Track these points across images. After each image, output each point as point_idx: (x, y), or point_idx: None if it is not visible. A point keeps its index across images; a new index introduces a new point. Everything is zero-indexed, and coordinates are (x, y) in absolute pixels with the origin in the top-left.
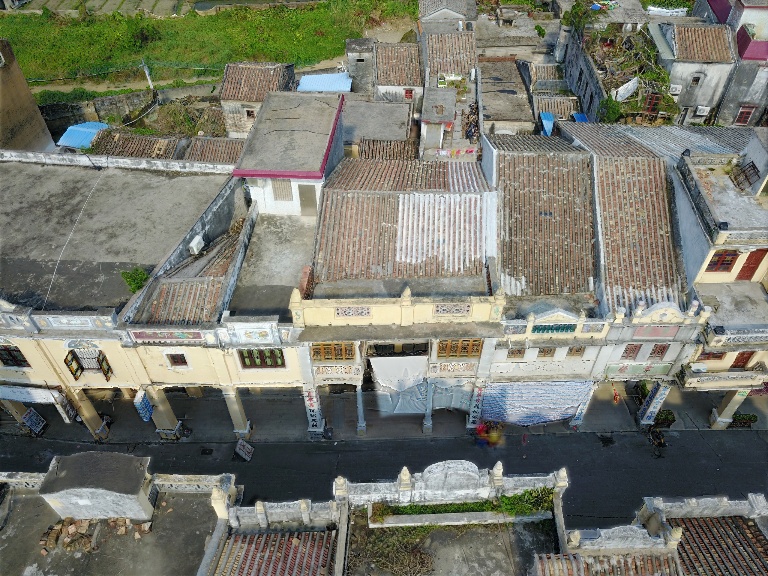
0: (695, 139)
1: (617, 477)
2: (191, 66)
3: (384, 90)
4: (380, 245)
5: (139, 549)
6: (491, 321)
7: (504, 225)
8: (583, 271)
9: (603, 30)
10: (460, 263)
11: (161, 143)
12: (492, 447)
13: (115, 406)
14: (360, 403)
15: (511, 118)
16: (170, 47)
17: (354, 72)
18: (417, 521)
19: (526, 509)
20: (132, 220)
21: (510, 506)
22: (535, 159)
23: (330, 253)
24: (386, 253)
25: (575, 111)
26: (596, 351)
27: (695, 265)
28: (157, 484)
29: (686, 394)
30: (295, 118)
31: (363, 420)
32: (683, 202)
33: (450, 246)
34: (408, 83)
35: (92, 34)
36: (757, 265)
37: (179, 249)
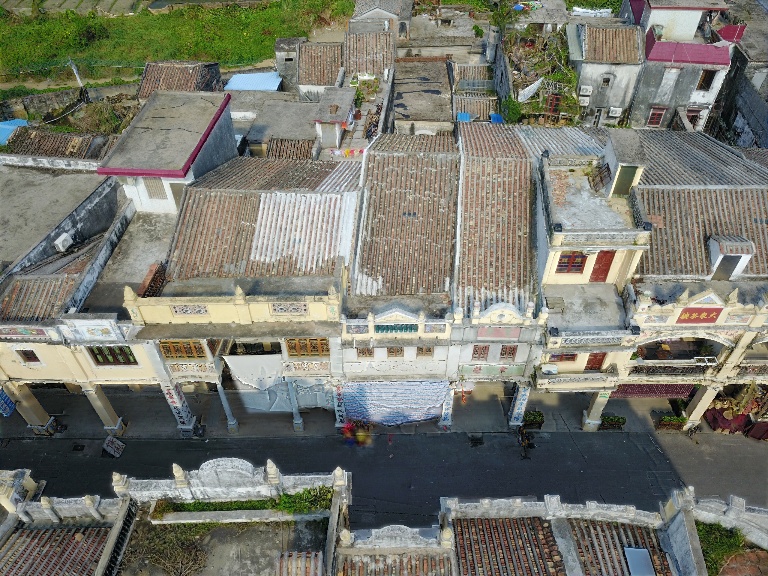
0: (582, 140)
1: (480, 478)
2: (133, 64)
3: (306, 89)
4: (236, 244)
5: None
6: (329, 320)
7: (367, 225)
8: (441, 271)
9: (524, 30)
10: (313, 262)
11: (76, 141)
12: (361, 446)
13: None
14: (224, 401)
15: (430, 118)
16: (116, 45)
17: (284, 71)
18: (196, 518)
19: (304, 507)
20: (6, 217)
21: (289, 504)
22: (405, 159)
23: (185, 251)
24: (241, 252)
25: (493, 111)
26: (445, 351)
27: (542, 266)
28: None
29: (564, 395)
30: (176, 117)
31: (232, 418)
32: (540, 203)
33: (305, 245)
34: (328, 82)
35: (41, 32)
36: (608, 267)
37: (42, 246)
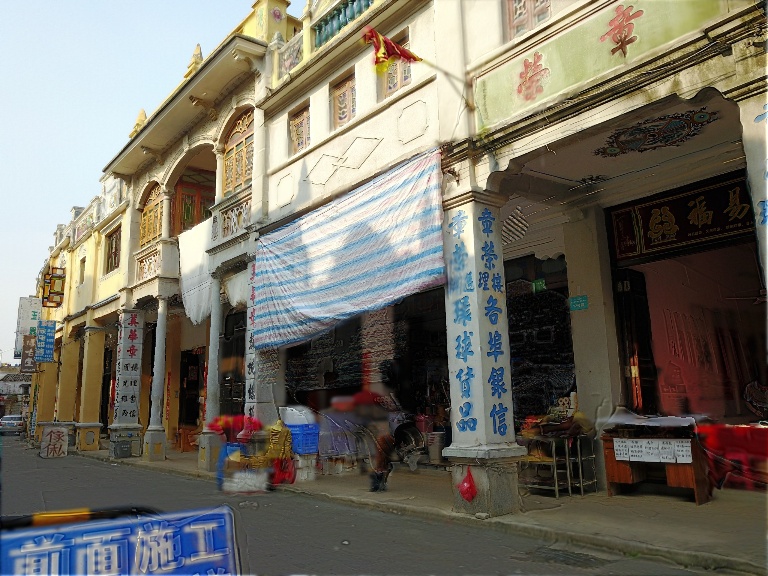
0: None
1: None
2: None
3: None
4: None
5: None
6: None
7: None
8: None
9: None
10: None
11: None
12: (236, 493)
13: None
14: (157, 355)
15: None
16: None
17: None
18: None
19: None
20: None
21: None
22: None
23: None
24: None
25: None
26: None
27: None
28: None
29: None
30: None
31: (156, 414)
32: None
33: None
34: None
35: None
36: None
37: None
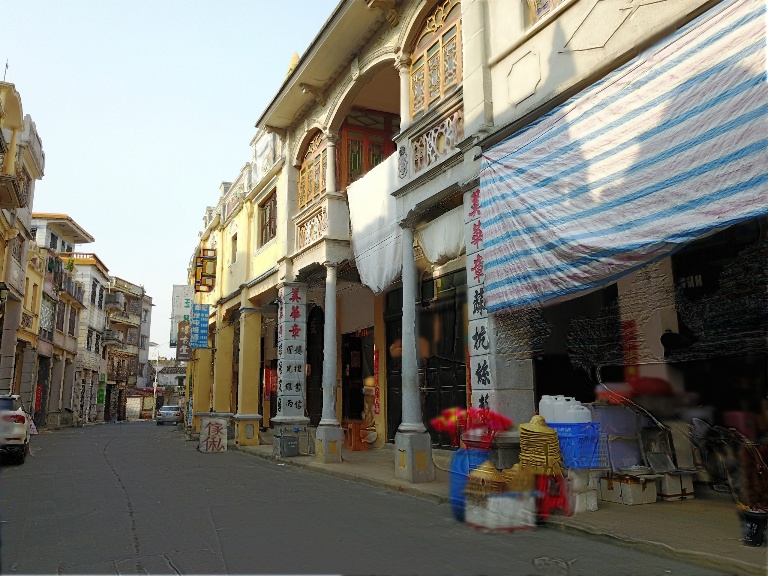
0: None
1: None
2: None
3: None
4: None
5: None
6: None
7: None
8: None
9: None
10: None
11: None
12: (487, 528)
13: None
14: (327, 334)
15: None
16: None
17: None
18: None
19: None
20: None
21: None
22: None
23: None
24: None
25: None
26: None
27: None
28: None
29: None
30: None
31: (328, 406)
32: None
33: None
34: None
35: None
36: None
37: None
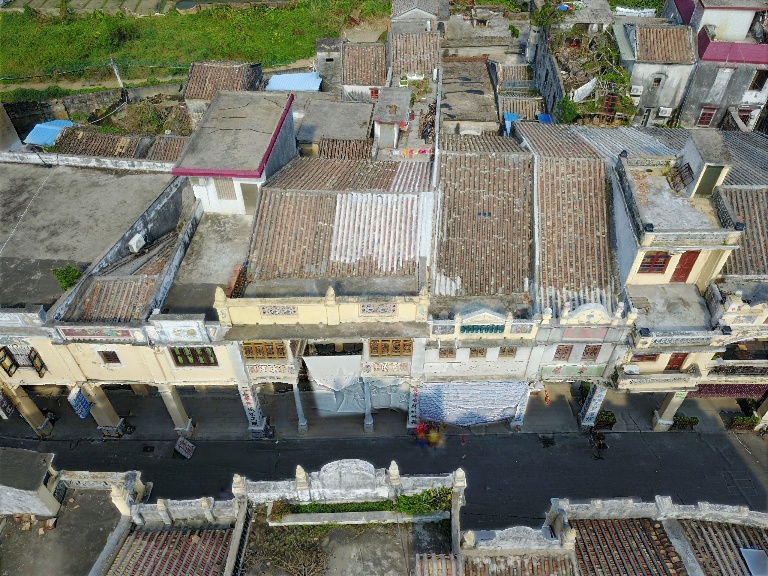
0: (645, 140)
1: (555, 478)
2: (166, 65)
3: (350, 90)
4: (315, 244)
5: (41, 545)
6: (418, 321)
7: (442, 225)
8: (519, 272)
9: (569, 30)
10: (393, 263)
11: (124, 141)
12: (432, 447)
13: (61, 403)
14: (298, 402)
15: (476, 118)
16: (147, 46)
17: (324, 71)
18: (315, 520)
19: (424, 509)
20: (75, 218)
21: (408, 506)
22: (477, 159)
23: (264, 252)
24: (320, 252)
25: (540, 111)
26: (528, 352)
27: (626, 266)
28: (64, 480)
29: (631, 396)
30: (242, 117)
31: (303, 419)
32: (619, 203)
33: (384, 246)
34: (373, 83)
35: (71, 32)
36: (691, 267)
37: (117, 247)
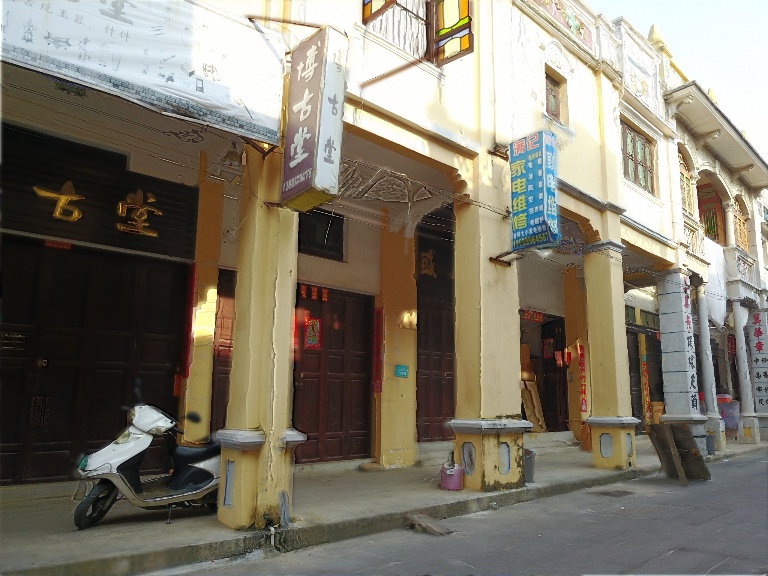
0: None
1: None
2: None
3: None
4: None
5: None
6: None
7: None
8: None
9: None
10: None
11: None
12: None
13: None
14: None
15: None
16: None
17: None
18: None
19: None
20: None
21: None
22: None
23: None
24: None
25: None
26: None
27: None
28: None
29: None
30: None
31: None
32: None
33: None
34: None
35: None
36: None
37: None
